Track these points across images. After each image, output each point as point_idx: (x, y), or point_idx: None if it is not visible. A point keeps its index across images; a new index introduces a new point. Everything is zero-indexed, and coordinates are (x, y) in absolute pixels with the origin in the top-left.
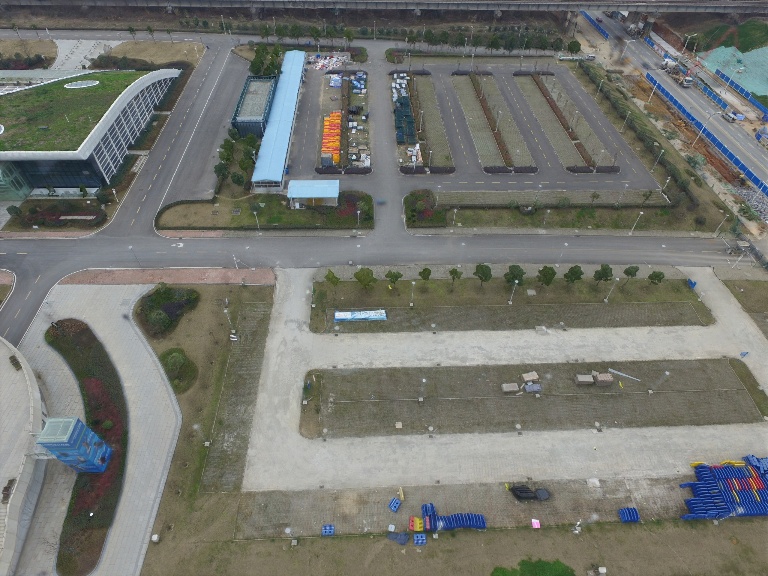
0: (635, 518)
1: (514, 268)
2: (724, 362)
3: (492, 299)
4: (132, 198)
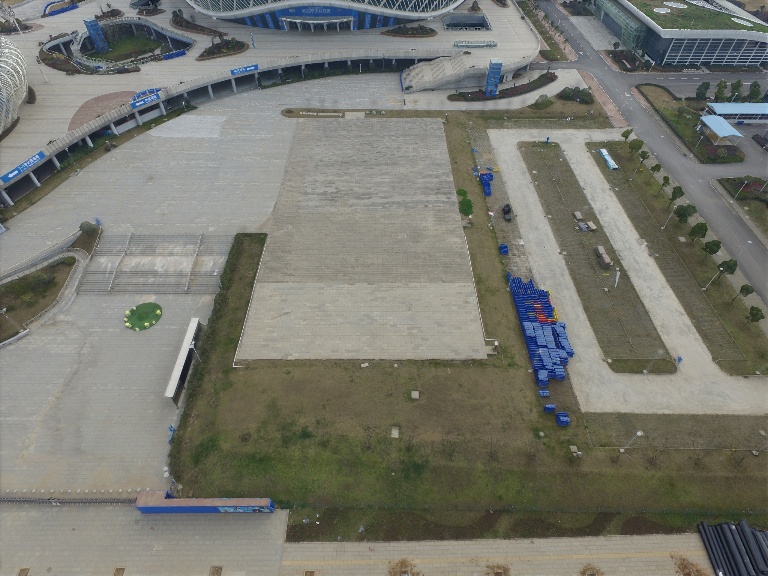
0: (502, 248)
1: None
2: (667, 356)
3: (660, 217)
4: (657, 75)
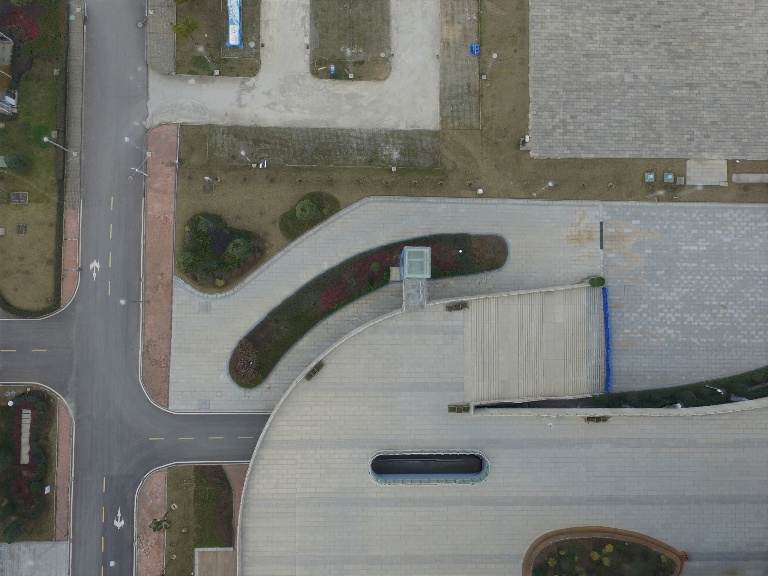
0: None
1: None
2: None
3: None
4: None
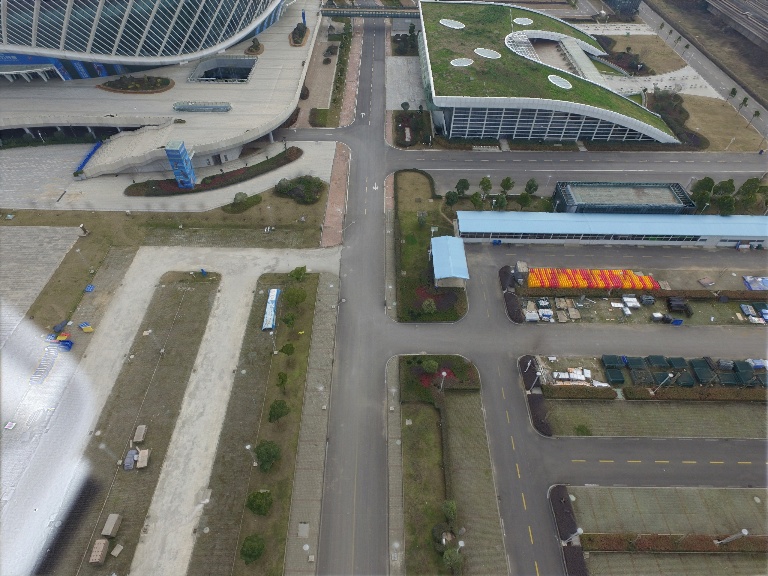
0: None
1: (267, 445)
2: None
3: None
4: (436, 154)
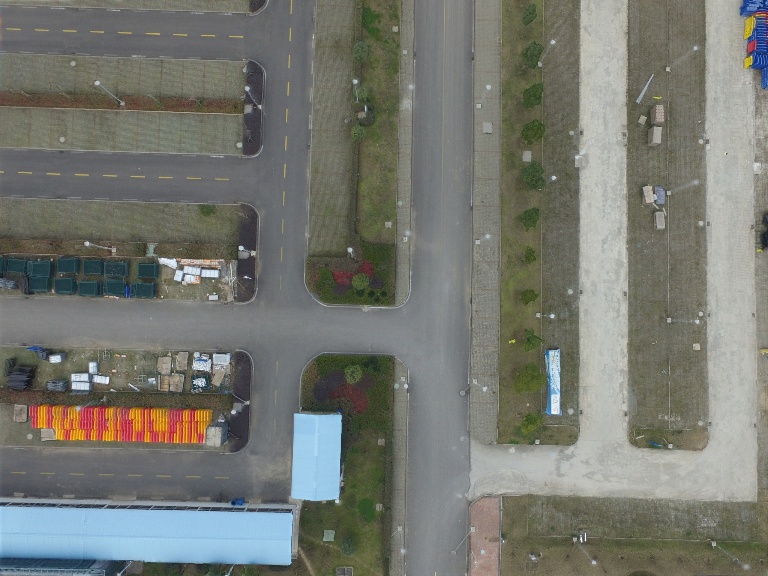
0: None
1: (536, 176)
2: None
3: None
4: None
